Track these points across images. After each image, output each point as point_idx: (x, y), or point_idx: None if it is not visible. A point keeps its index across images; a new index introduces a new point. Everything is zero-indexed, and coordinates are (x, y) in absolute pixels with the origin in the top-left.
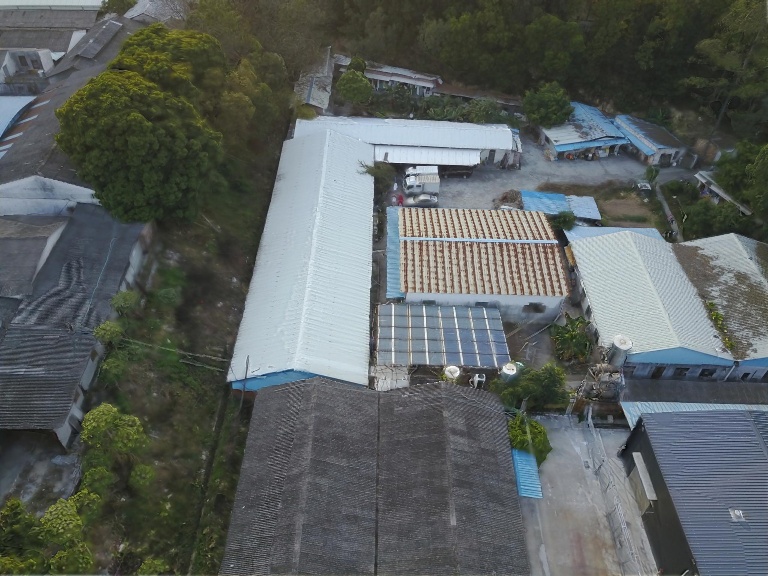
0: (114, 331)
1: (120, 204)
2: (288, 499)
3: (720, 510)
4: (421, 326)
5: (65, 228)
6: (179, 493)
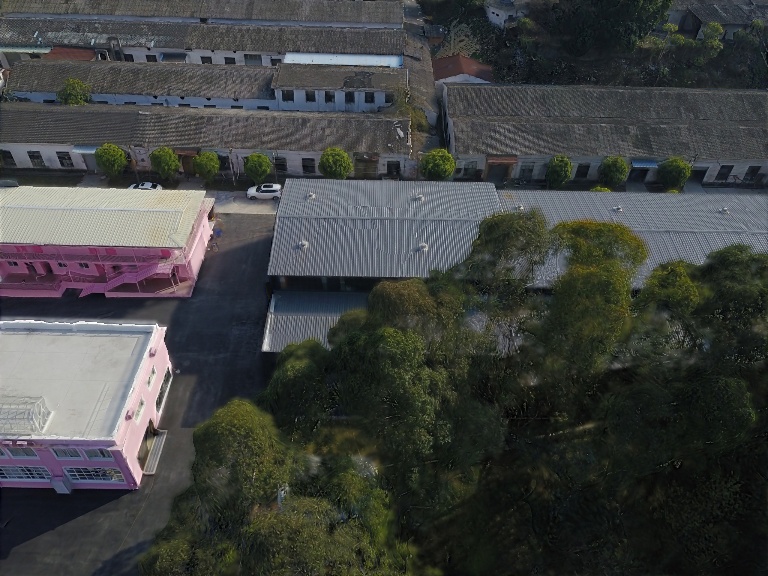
0: (759, 23)
1: None
2: None
3: None
4: None
5: None
6: (697, 86)
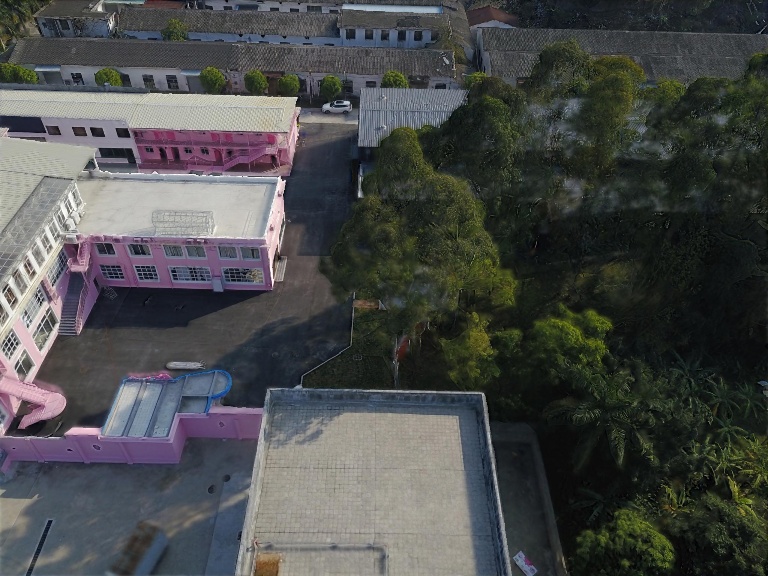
0: None
1: None
2: None
3: None
4: None
5: None
6: None
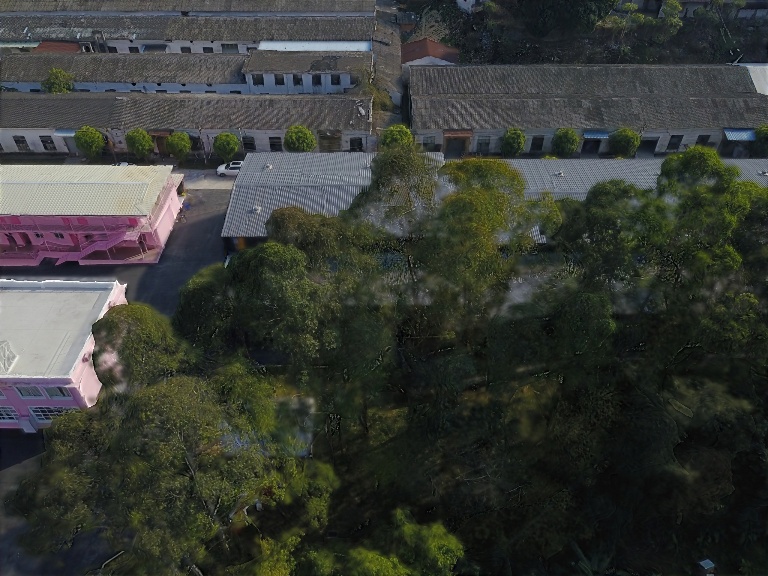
0: (718, 0)
1: None
2: (672, 66)
3: (763, 169)
4: None
5: None
6: (659, 63)
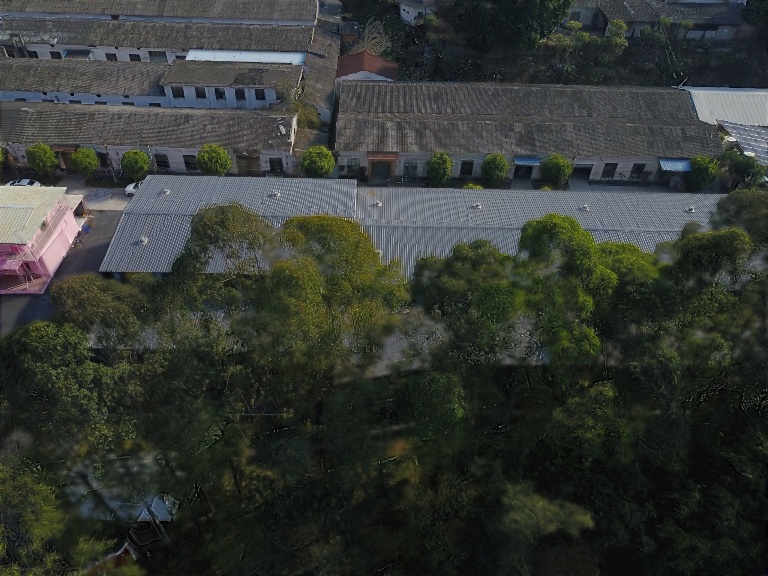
0: (665, 21)
1: (748, 4)
2: None
3: None
4: (766, 140)
5: (720, 3)
6: (604, 84)
